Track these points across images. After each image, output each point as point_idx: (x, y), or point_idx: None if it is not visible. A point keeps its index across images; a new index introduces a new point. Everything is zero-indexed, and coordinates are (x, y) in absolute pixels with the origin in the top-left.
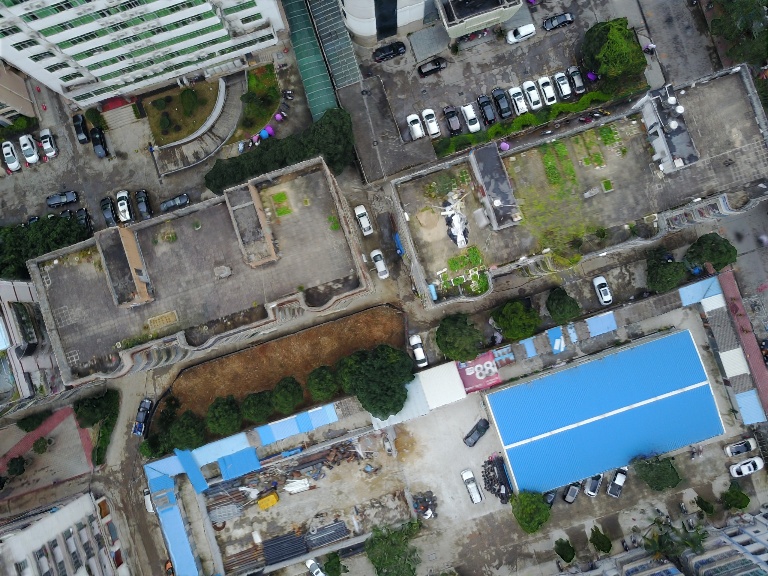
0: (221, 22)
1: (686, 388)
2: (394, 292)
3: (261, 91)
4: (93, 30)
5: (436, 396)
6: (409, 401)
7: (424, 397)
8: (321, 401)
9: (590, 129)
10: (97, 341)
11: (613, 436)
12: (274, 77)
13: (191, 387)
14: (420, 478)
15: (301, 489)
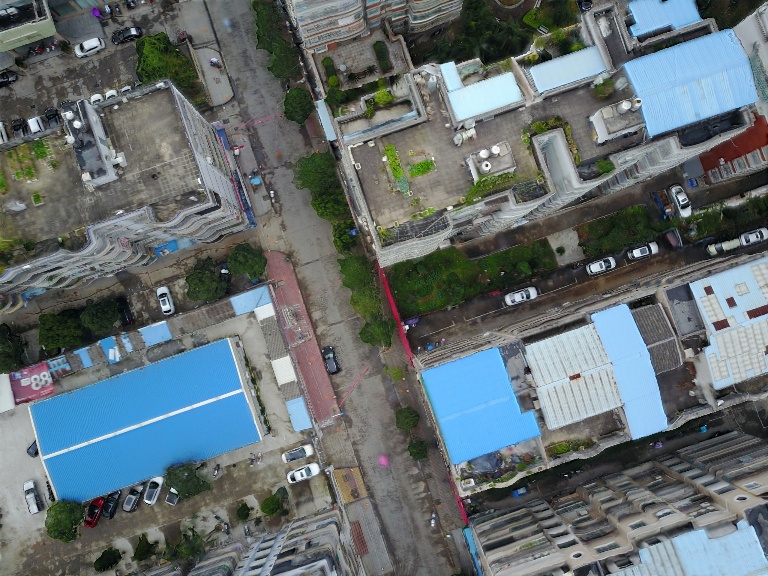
0: None
1: (221, 396)
2: None
3: None
4: None
5: None
6: None
7: None
8: None
9: (23, 144)
10: None
11: (151, 445)
12: None
13: None
14: None
15: None
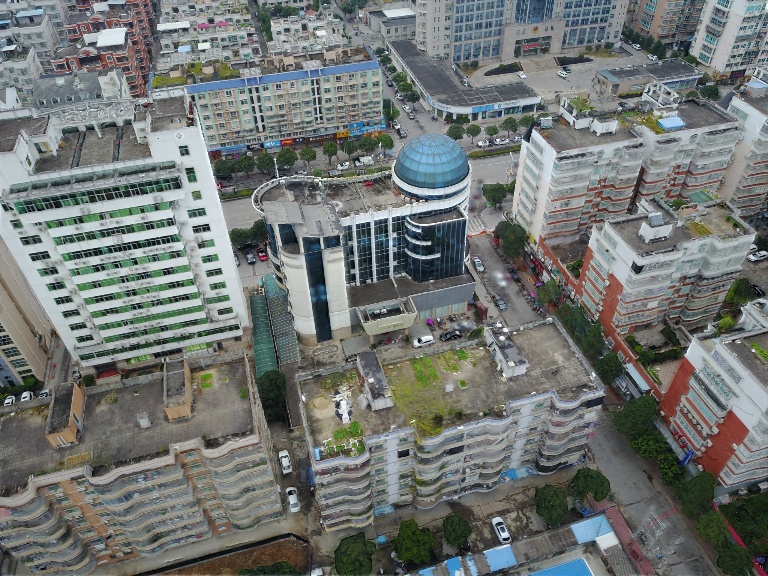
0: None
1: None
2: (303, 526)
3: None
4: (113, 292)
5: None
6: None
7: None
8: None
9: (449, 351)
10: (14, 474)
11: None
12: None
13: None
14: None
15: None
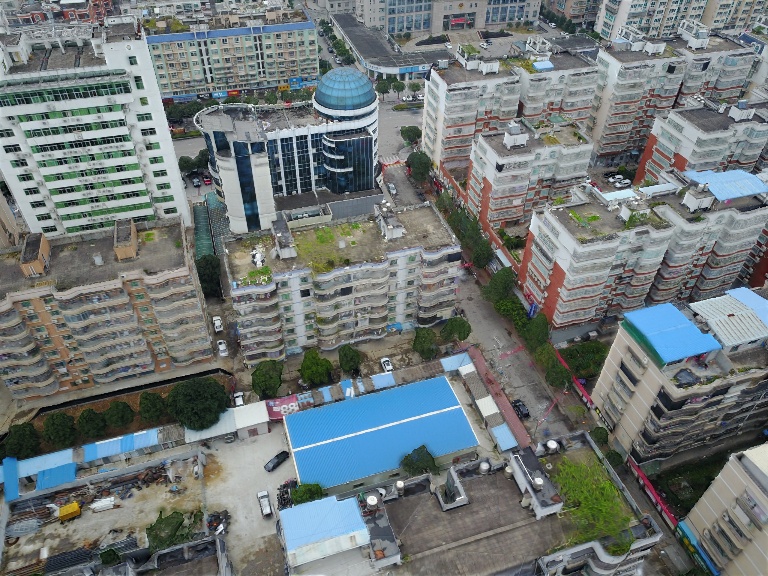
0: None
1: (443, 410)
2: (230, 366)
3: None
4: (74, 185)
5: (244, 421)
6: (221, 424)
7: (234, 421)
8: None
9: (345, 223)
10: None
11: (386, 444)
12: None
13: (41, 426)
14: (219, 500)
15: (105, 506)
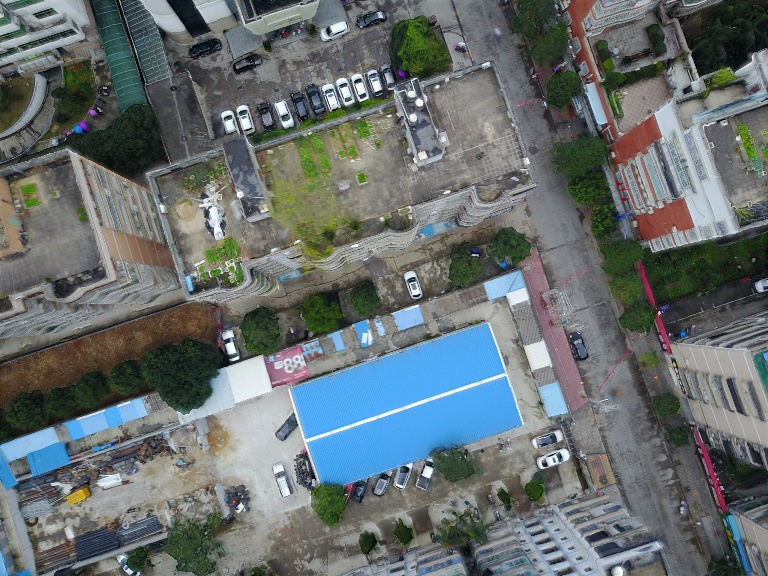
0: (7, 17)
1: (484, 380)
2: None
3: (78, 87)
4: None
5: (242, 390)
6: (215, 395)
7: (230, 391)
8: (130, 396)
9: (346, 123)
10: None
11: (413, 428)
12: (91, 73)
13: (5, 383)
14: (233, 472)
15: (113, 484)
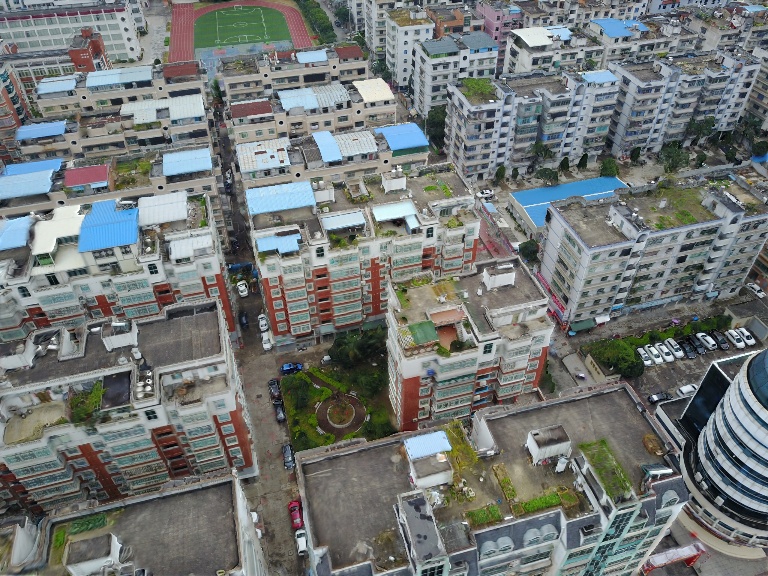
0: None
1: (536, 205)
2: None
3: None
4: None
5: None
6: None
7: None
8: None
9: None
10: None
11: (571, 192)
12: None
13: None
14: None
15: None
